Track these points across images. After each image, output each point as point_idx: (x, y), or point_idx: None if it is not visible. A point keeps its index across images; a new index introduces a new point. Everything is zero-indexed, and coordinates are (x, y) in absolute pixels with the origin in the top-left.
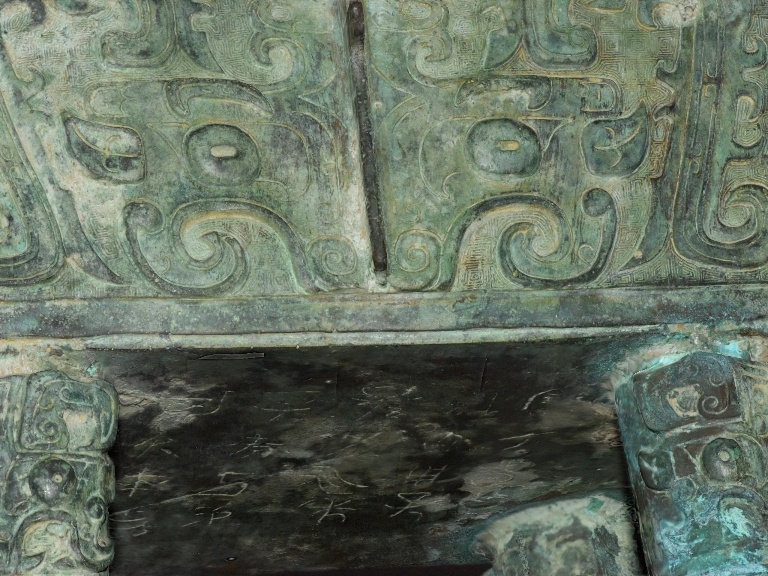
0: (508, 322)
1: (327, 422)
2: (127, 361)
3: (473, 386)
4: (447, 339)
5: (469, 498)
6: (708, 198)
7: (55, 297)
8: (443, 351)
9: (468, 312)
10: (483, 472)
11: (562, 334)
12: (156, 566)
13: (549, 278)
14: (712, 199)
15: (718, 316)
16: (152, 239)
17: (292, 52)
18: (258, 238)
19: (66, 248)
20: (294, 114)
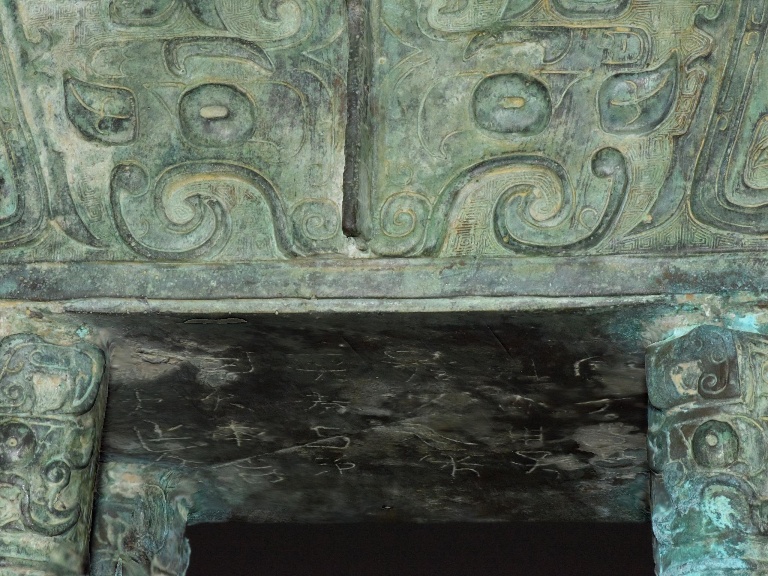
0: (497, 290)
1: (376, 383)
2: (117, 323)
3: (499, 352)
4: (433, 307)
5: (596, 458)
6: (734, 157)
7: (35, 260)
8: (435, 319)
9: (455, 279)
10: (589, 434)
11: (558, 303)
12: (314, 511)
13: (543, 244)
14: (738, 158)
15: (731, 286)
16: (135, 202)
17: (301, 7)
18: (243, 201)
19: (52, 211)
20: (295, 72)
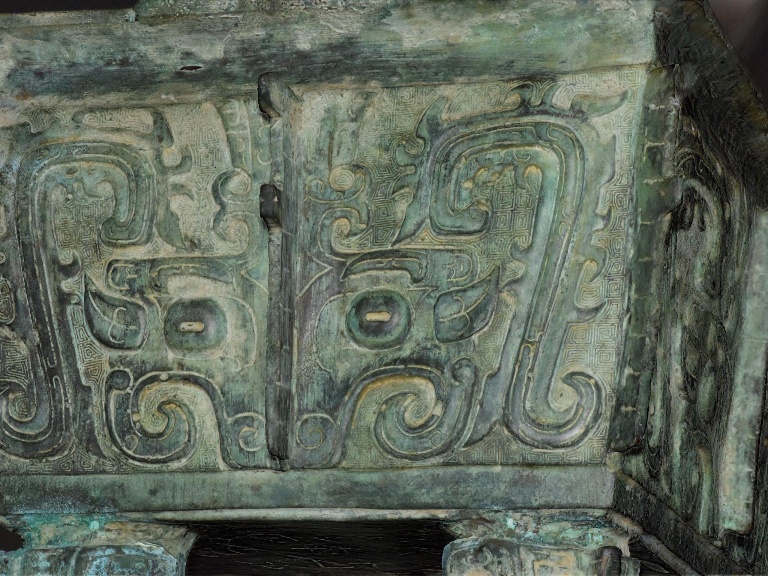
0: None
1: None
2: None
3: None
4: None
5: None
6: None
7: None
8: None
9: (721, 573)
10: None
11: None
12: None
13: None
14: None
15: None
16: None
17: None
18: None
19: None
20: None
